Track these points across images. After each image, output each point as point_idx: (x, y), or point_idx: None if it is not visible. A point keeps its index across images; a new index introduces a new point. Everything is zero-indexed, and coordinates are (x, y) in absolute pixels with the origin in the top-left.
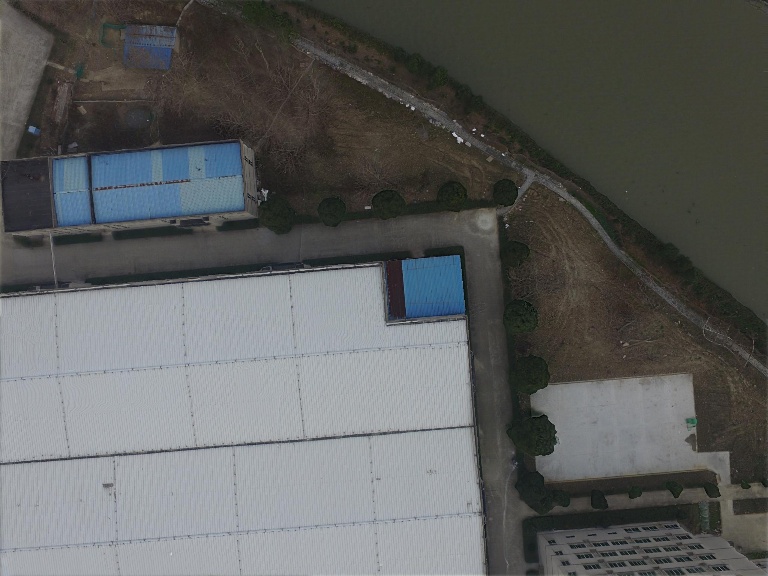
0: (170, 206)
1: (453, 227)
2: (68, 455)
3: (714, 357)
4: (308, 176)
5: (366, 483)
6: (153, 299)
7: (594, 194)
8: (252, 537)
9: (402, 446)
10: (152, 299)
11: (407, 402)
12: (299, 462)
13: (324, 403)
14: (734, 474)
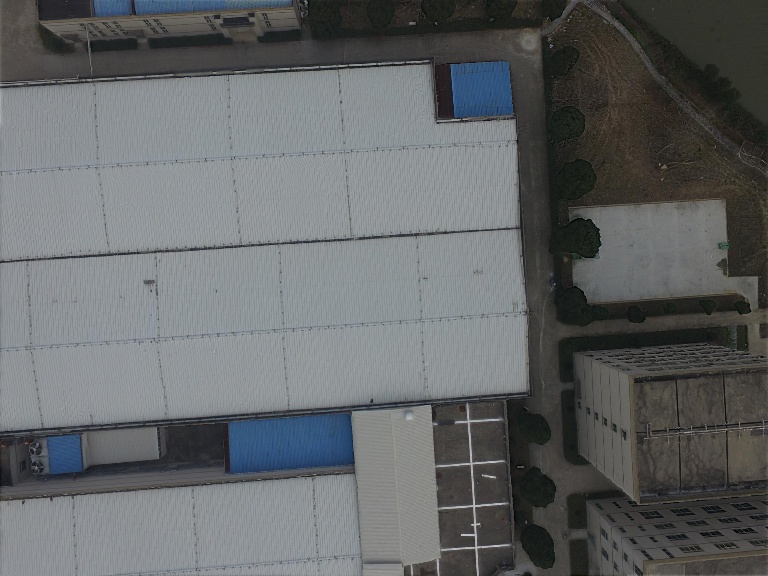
0: (214, 0)
1: (497, 46)
2: (107, 251)
3: (748, 181)
4: None
5: (413, 282)
6: (198, 91)
7: (637, 17)
8: (298, 335)
9: (449, 246)
10: (197, 91)
11: (455, 202)
12: (346, 261)
13: (372, 201)
14: (762, 298)
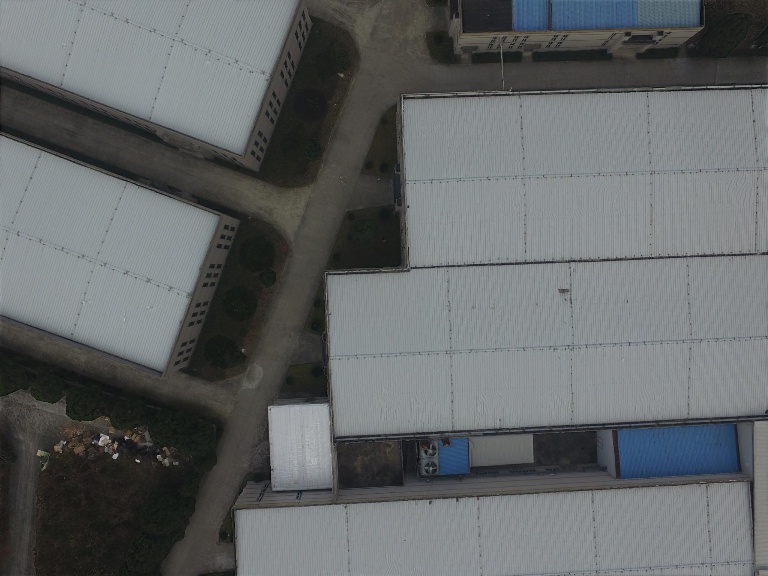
0: (626, 18)
1: None
2: (524, 259)
3: None
4: (729, 9)
5: None
6: (618, 106)
7: None
8: (704, 345)
9: None
10: (617, 106)
11: None
12: (750, 275)
13: None
14: None
